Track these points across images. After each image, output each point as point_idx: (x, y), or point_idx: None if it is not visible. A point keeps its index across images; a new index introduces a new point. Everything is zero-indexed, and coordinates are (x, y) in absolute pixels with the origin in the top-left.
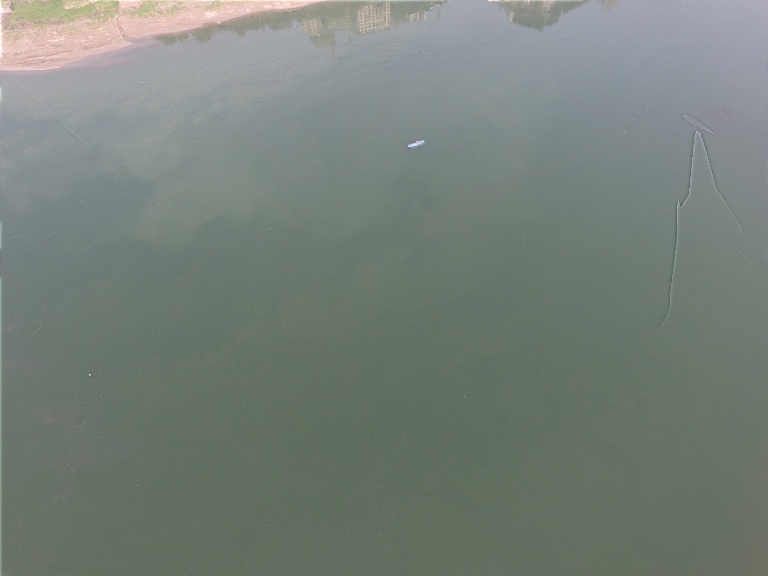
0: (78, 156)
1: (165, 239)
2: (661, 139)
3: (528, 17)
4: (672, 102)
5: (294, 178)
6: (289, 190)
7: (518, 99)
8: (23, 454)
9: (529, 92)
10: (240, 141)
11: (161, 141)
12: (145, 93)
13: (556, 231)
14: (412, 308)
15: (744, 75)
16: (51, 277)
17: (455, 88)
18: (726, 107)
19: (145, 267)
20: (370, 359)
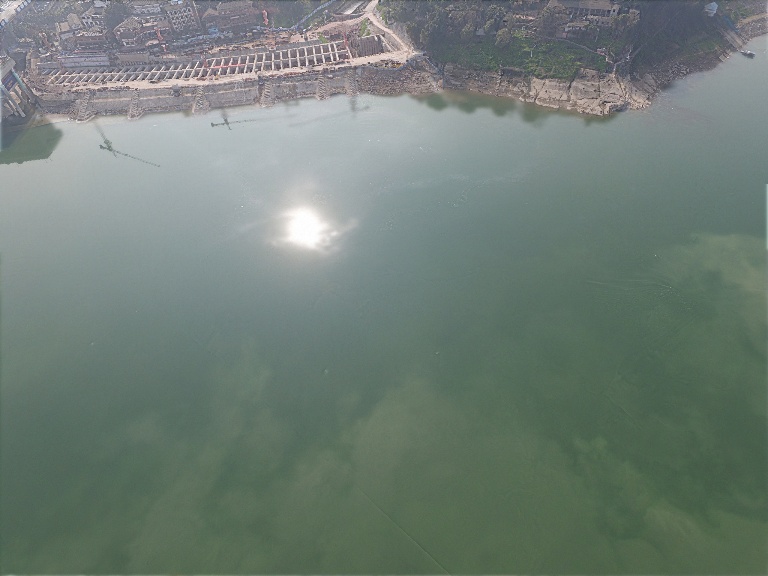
0: (376, 471)
1: (209, 323)
2: None
3: None
4: None
5: (33, 432)
6: (49, 407)
7: None
8: (272, 177)
9: None
10: (98, 542)
11: (242, 526)
12: None
13: None
14: None
15: None
16: (304, 267)
17: None
18: None
19: (219, 282)
20: (48, 233)
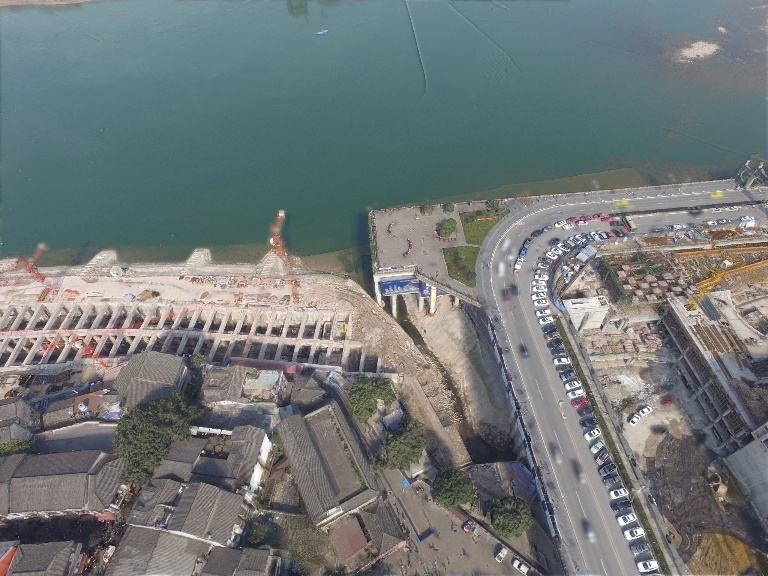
0: (96, 47)
1: (150, 81)
2: (491, 24)
3: None
4: (511, 6)
5: (237, 52)
6: (232, 58)
7: (398, 5)
8: None
9: None
10: (205, 37)
11: (151, 38)
12: (142, 14)
13: (401, 72)
14: (294, 101)
15: None
16: (79, 96)
17: (363, 7)
18: (548, 7)
19: (136, 91)
20: (264, 123)
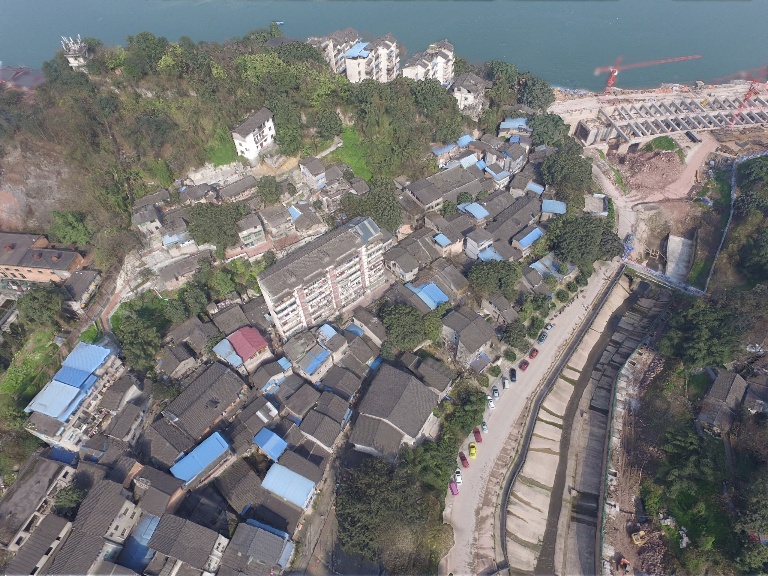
0: None
1: None
2: None
3: None
4: None
5: None
6: None
7: None
8: (612, 35)
9: None
10: None
11: None
12: None
13: None
14: (747, 2)
15: None
16: None
17: None
18: None
19: None
20: (738, 16)
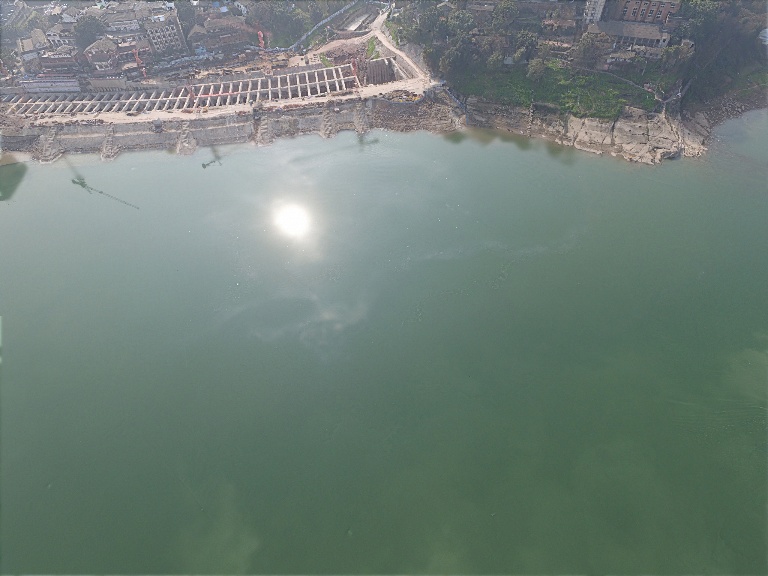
0: None
1: (199, 455)
2: None
3: None
4: None
5: None
6: None
7: None
8: (272, 241)
9: None
10: None
11: None
12: None
13: None
14: None
15: None
16: (316, 374)
17: None
18: None
19: (210, 396)
20: (0, 318)
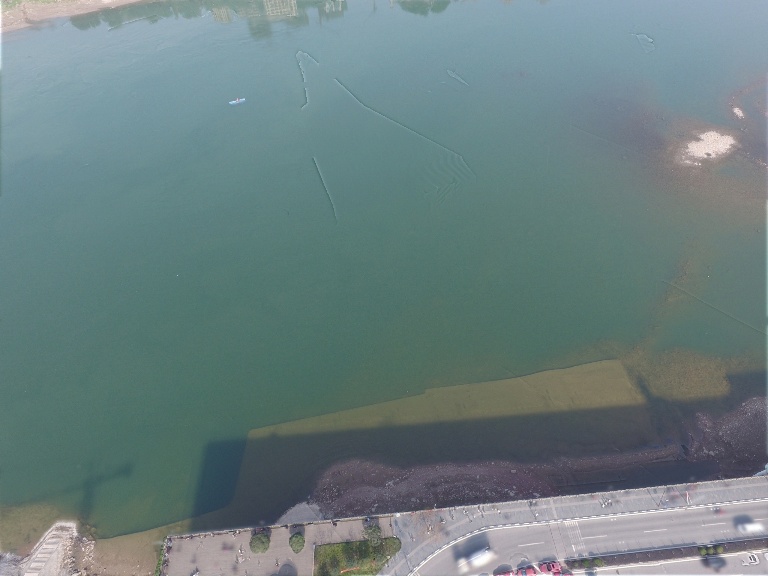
0: None
1: None
2: (448, 95)
3: (412, 3)
4: (477, 67)
5: (124, 127)
6: (116, 136)
7: (336, 64)
8: None
9: (345, 58)
10: (93, 101)
11: (26, 101)
12: (27, 64)
13: None
14: (170, 218)
15: (551, 44)
16: None
17: None
18: (522, 70)
19: None
20: (122, 254)
